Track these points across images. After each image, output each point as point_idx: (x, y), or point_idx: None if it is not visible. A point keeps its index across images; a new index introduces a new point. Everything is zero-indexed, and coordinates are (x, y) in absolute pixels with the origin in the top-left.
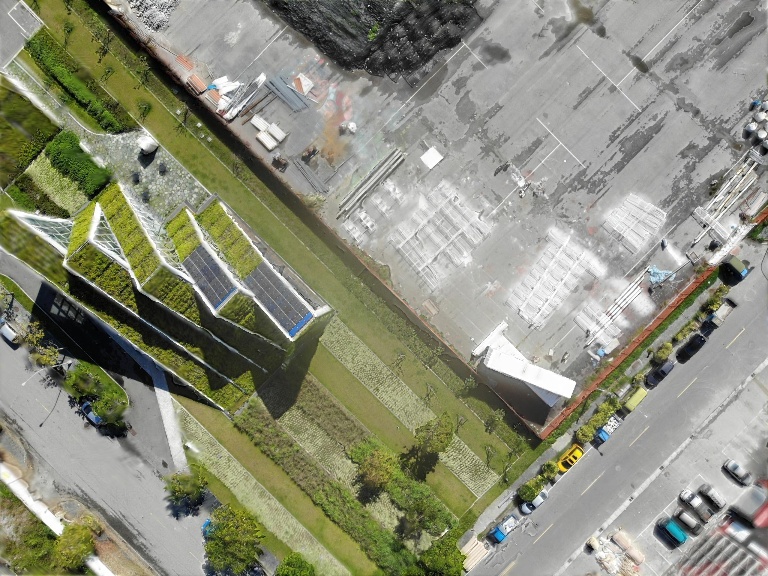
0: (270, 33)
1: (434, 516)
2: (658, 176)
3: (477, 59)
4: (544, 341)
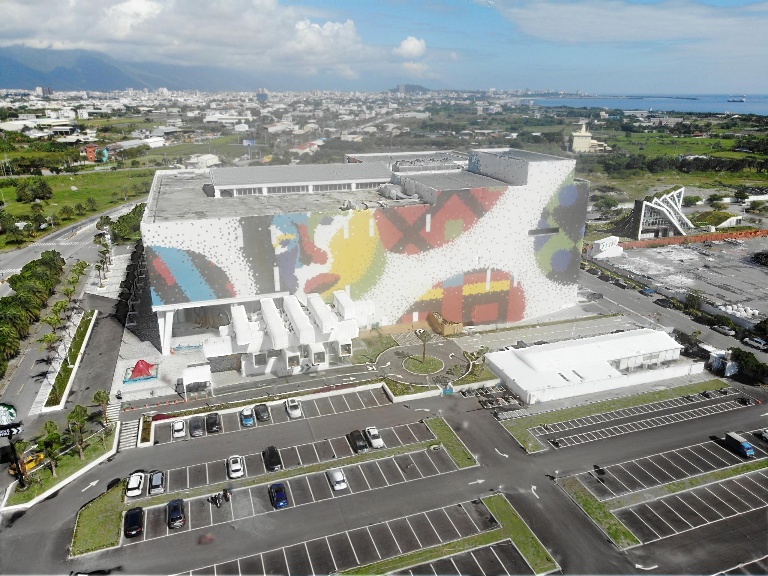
0: (767, 248)
1: None
2: None
3: (766, 271)
4: None
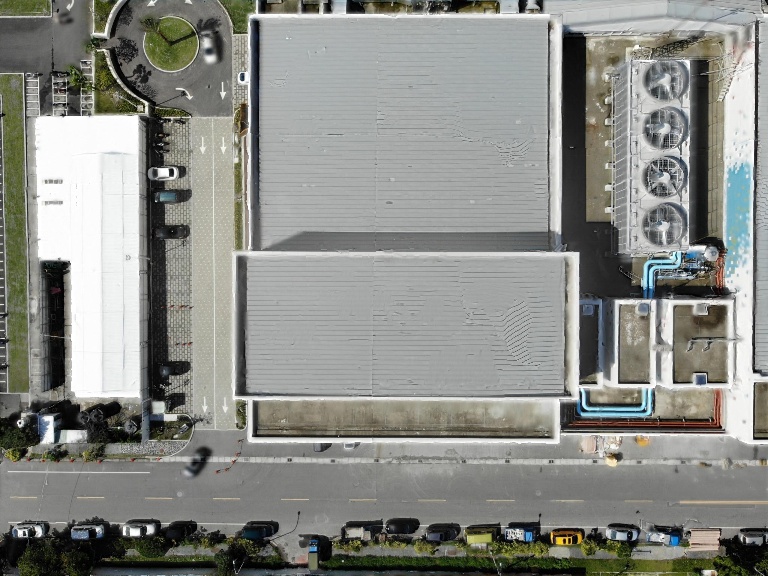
0: None
1: None
2: None
3: None
4: None
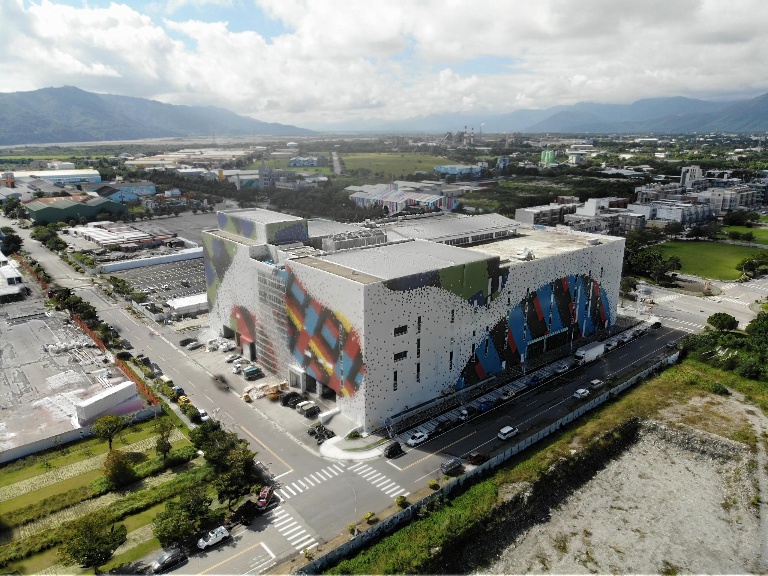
0: None
1: (164, 426)
2: None
3: None
4: None
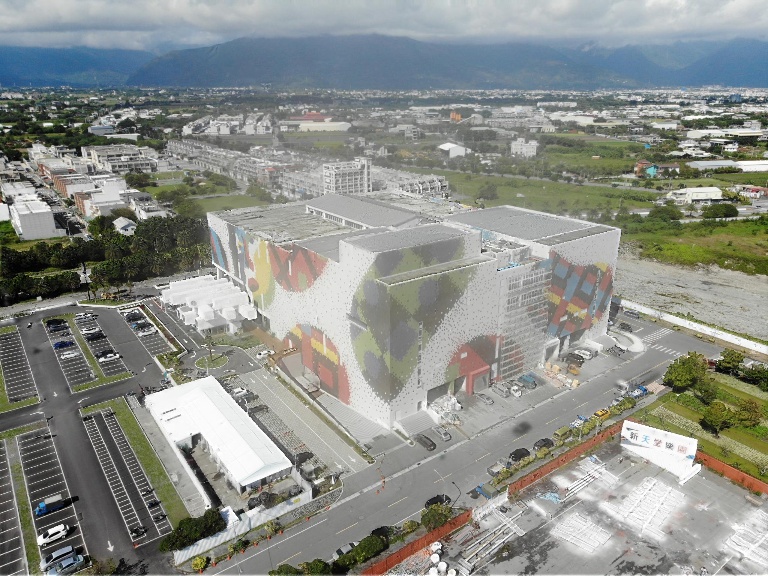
0: None
1: None
2: (564, 567)
3: None
4: (642, 471)
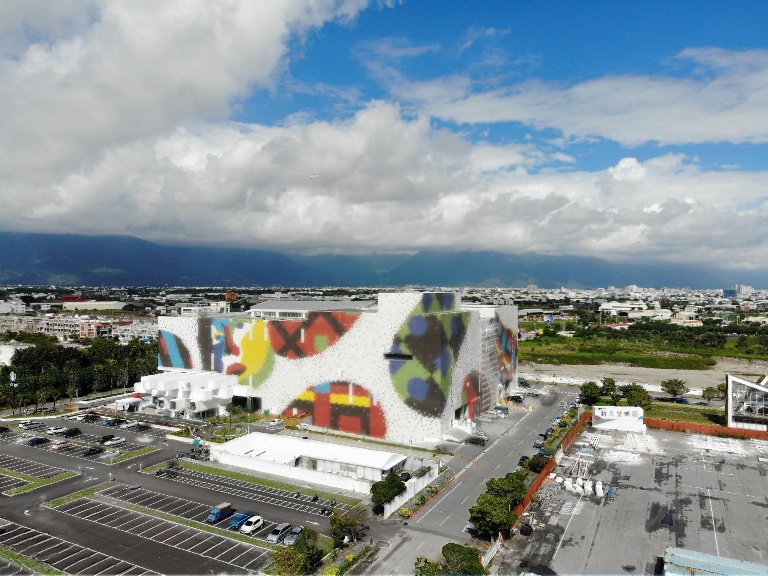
0: None
1: None
2: None
3: None
4: None
